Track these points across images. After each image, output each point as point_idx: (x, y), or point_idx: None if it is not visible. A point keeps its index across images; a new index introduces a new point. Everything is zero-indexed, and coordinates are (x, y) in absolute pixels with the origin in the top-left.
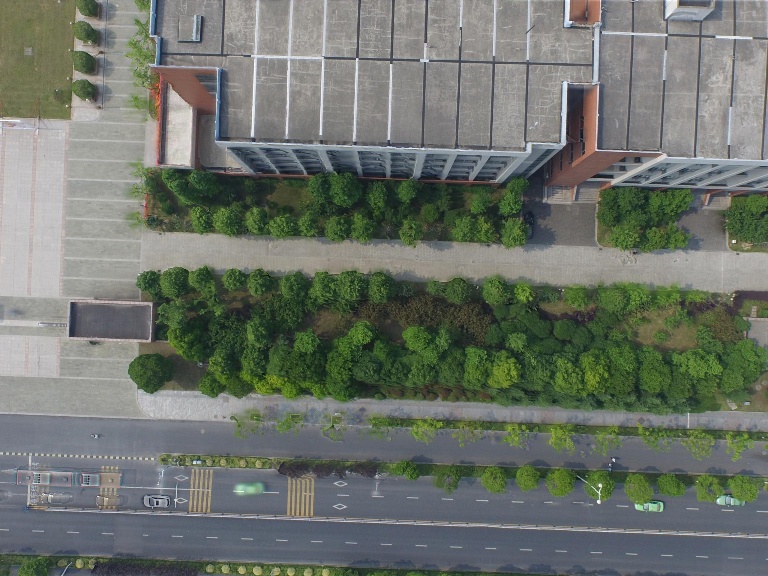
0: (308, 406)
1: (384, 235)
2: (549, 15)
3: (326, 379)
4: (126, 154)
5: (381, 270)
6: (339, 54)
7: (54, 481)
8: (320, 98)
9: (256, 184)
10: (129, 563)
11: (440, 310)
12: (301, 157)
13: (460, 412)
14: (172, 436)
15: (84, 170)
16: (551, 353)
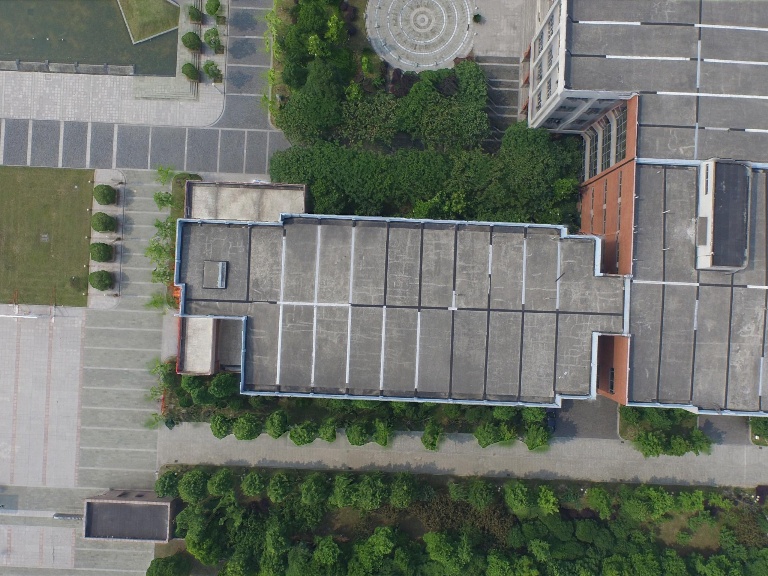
0: None
1: (404, 427)
2: (579, 262)
3: None
4: (143, 342)
5: (401, 462)
6: (366, 301)
7: None
8: (347, 345)
9: None
10: None
11: (461, 511)
12: None
13: None
14: None
15: (100, 358)
16: (573, 559)
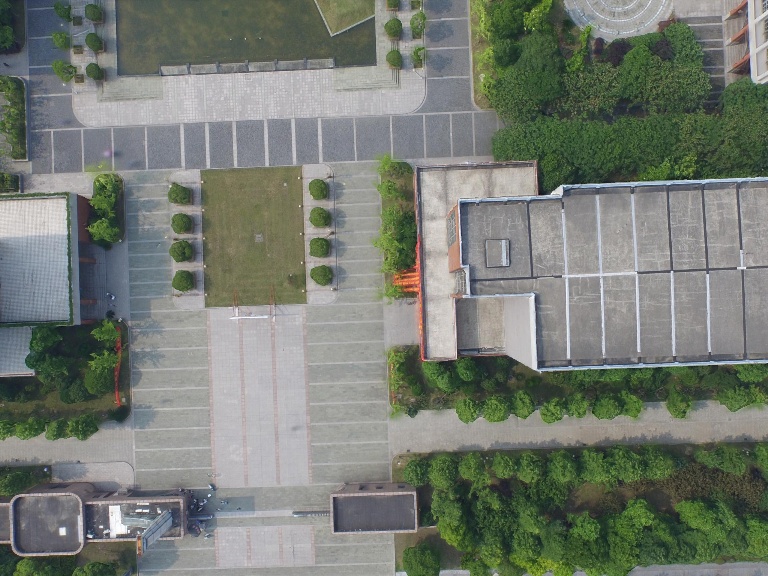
0: None
1: None
2: None
3: (608, 564)
4: (365, 334)
5: (636, 435)
6: (653, 268)
7: None
8: (636, 314)
9: (508, 361)
10: None
11: (709, 478)
12: None
13: (726, 573)
14: None
15: (324, 354)
16: None
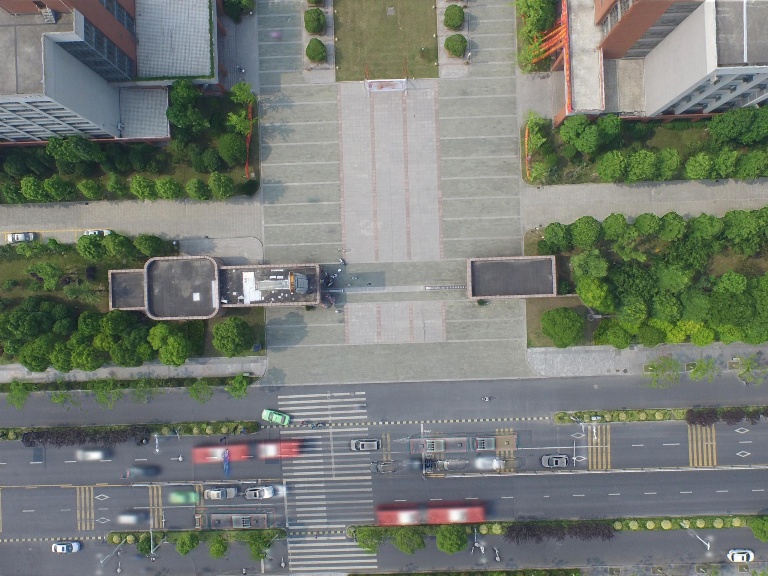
0: (703, 353)
1: None
2: None
3: (754, 319)
4: (498, 109)
5: None
6: None
7: (448, 447)
8: None
9: (646, 128)
10: (537, 525)
11: None
12: (758, 86)
13: None
14: (565, 394)
15: (456, 128)
16: None
